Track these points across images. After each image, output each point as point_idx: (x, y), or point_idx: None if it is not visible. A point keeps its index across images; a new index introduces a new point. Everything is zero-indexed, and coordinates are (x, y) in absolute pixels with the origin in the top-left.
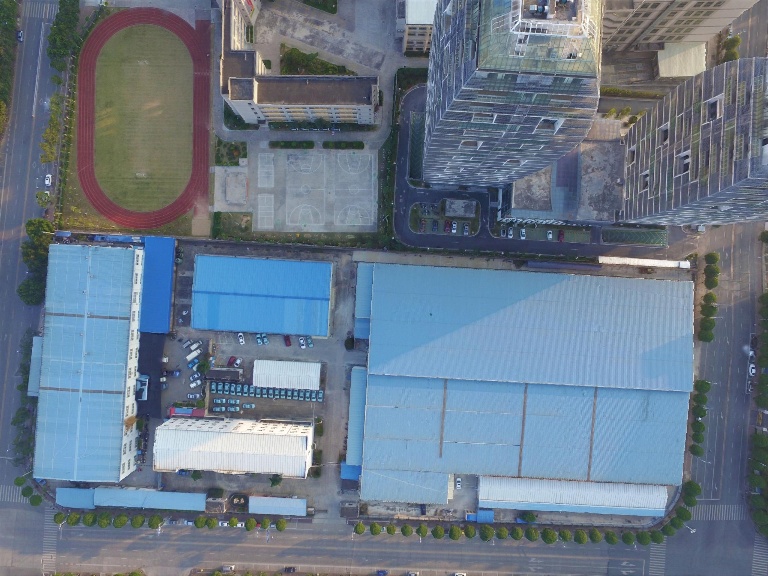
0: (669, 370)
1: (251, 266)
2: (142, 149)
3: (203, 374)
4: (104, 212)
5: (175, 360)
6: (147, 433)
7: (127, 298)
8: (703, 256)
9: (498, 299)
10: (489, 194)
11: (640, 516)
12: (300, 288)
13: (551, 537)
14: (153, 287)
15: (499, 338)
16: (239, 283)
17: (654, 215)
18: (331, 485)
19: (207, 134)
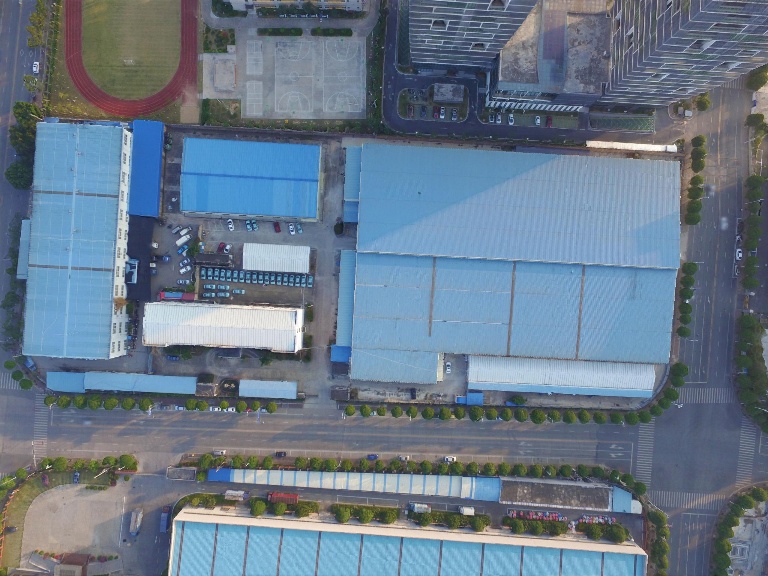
0: (656, 247)
1: (240, 148)
2: (130, 37)
3: (193, 260)
4: (92, 100)
5: (165, 247)
6: (137, 319)
7: (115, 176)
8: (690, 141)
9: (486, 178)
10: (477, 80)
11: (628, 400)
12: (289, 170)
13: (540, 416)
14: (142, 170)
15: (487, 216)
16: (228, 165)
17: (639, 69)
18: (321, 370)
19: (195, 22)
